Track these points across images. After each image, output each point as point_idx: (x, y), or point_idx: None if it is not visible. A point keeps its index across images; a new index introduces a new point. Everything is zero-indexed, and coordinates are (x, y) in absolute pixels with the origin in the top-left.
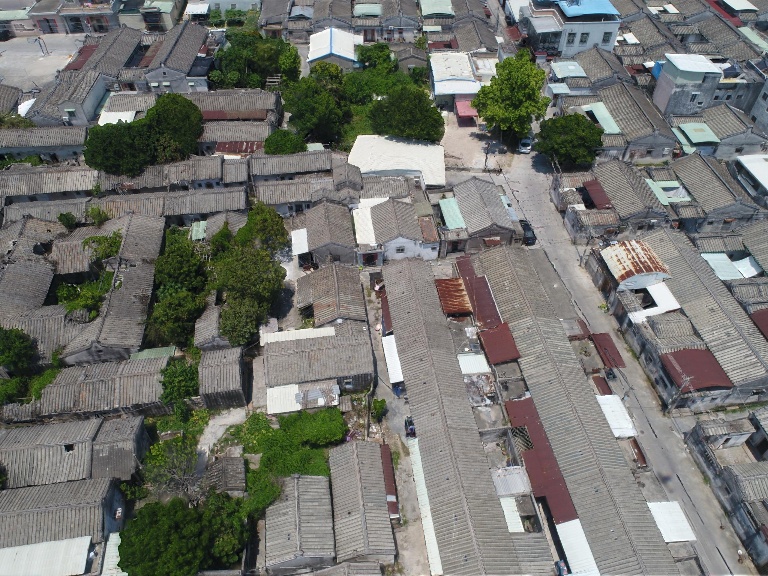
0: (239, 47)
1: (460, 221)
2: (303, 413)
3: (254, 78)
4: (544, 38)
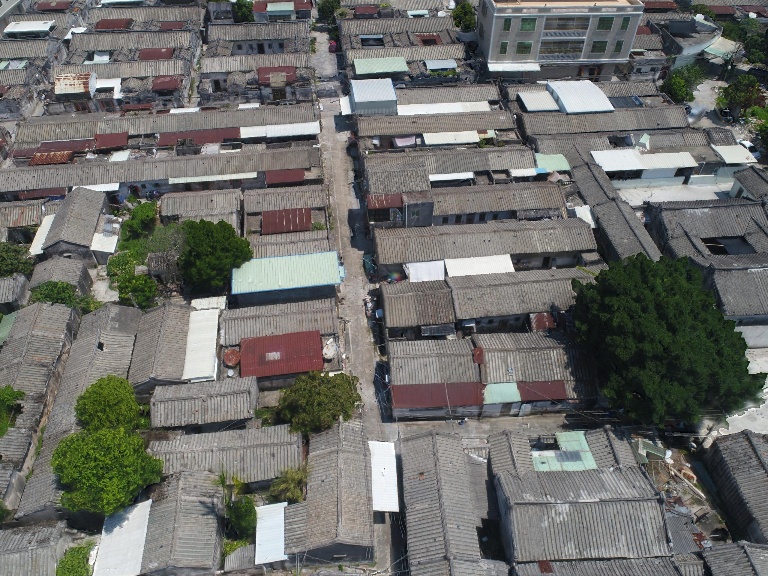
0: None
1: None
2: (127, 223)
3: None
4: None
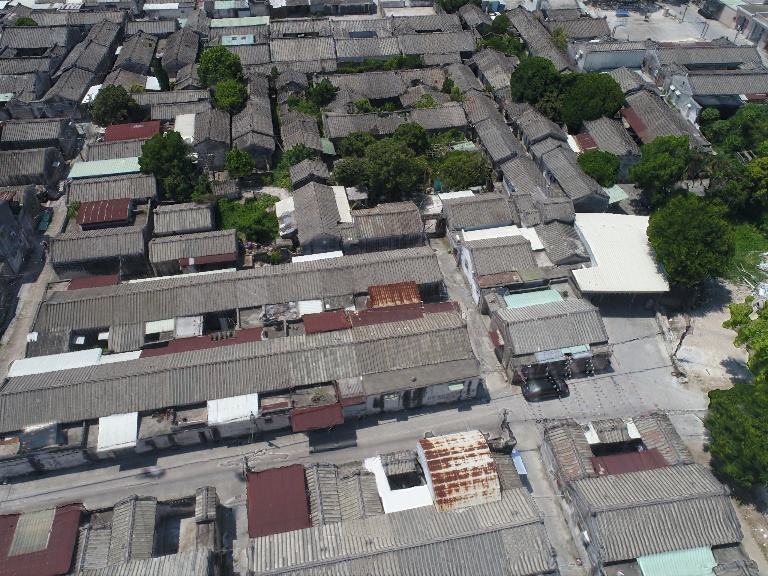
0: (763, 107)
1: (519, 304)
2: None
3: (732, 138)
4: None
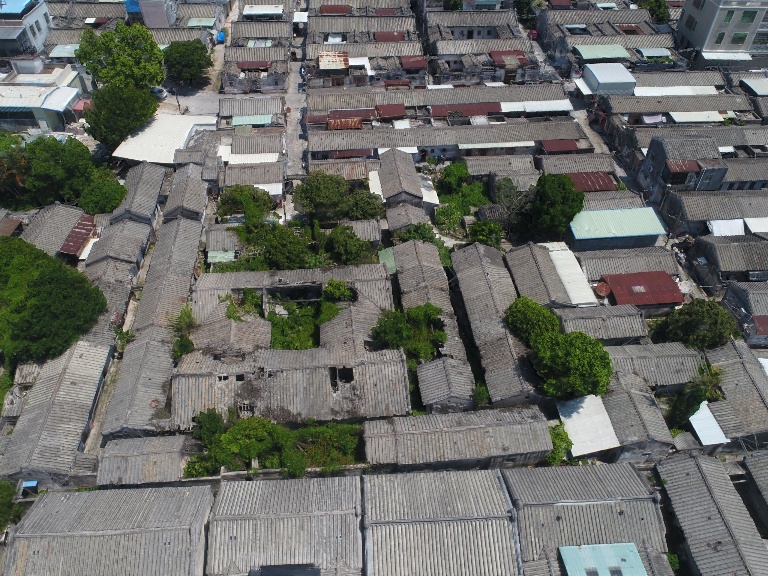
0: None
1: (264, 117)
2: (446, 179)
3: None
4: (20, 41)
